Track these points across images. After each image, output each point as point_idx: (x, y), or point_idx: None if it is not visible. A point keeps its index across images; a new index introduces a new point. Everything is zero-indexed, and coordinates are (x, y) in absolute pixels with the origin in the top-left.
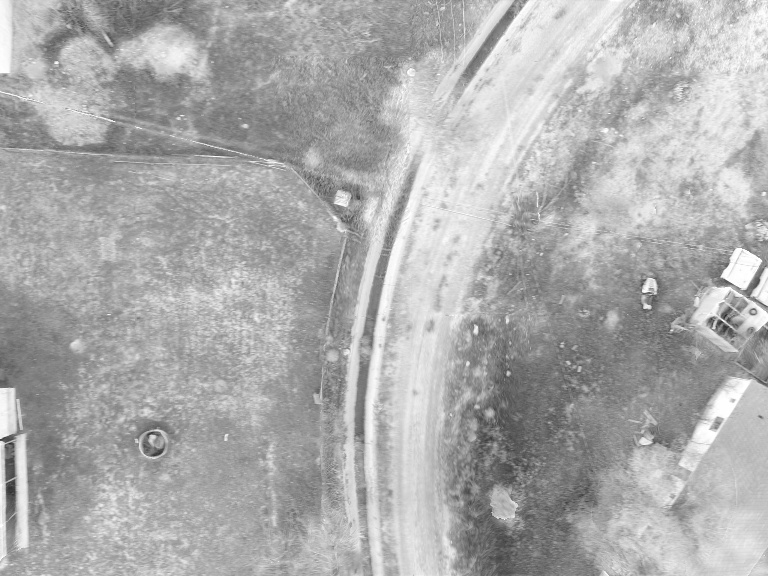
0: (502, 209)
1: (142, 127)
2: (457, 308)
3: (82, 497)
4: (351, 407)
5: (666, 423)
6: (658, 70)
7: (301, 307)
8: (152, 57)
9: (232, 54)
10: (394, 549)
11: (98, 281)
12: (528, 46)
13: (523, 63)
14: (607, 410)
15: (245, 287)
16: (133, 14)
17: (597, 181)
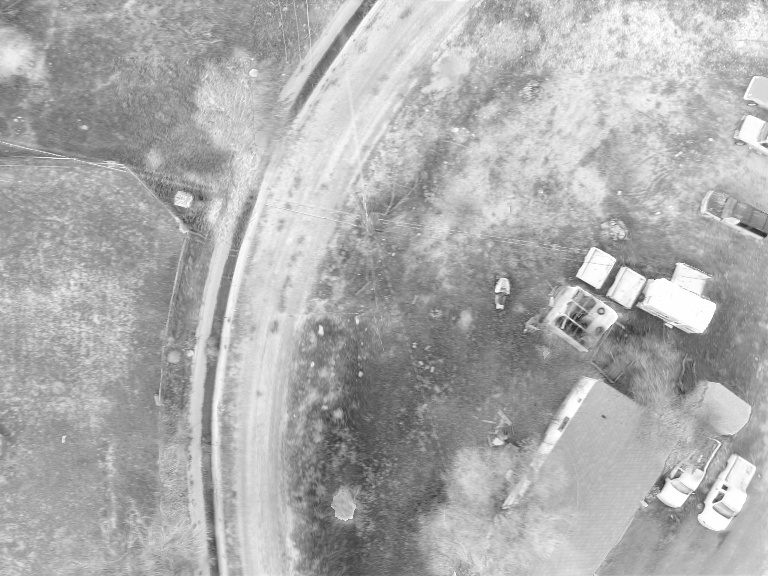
0: (346, 209)
1: None
2: (301, 309)
3: None
4: (197, 408)
5: (520, 423)
6: (509, 69)
7: (143, 308)
8: None
9: (70, 56)
10: (238, 551)
11: None
12: (374, 46)
13: (368, 63)
14: (460, 410)
15: (84, 288)
16: None
17: (450, 181)
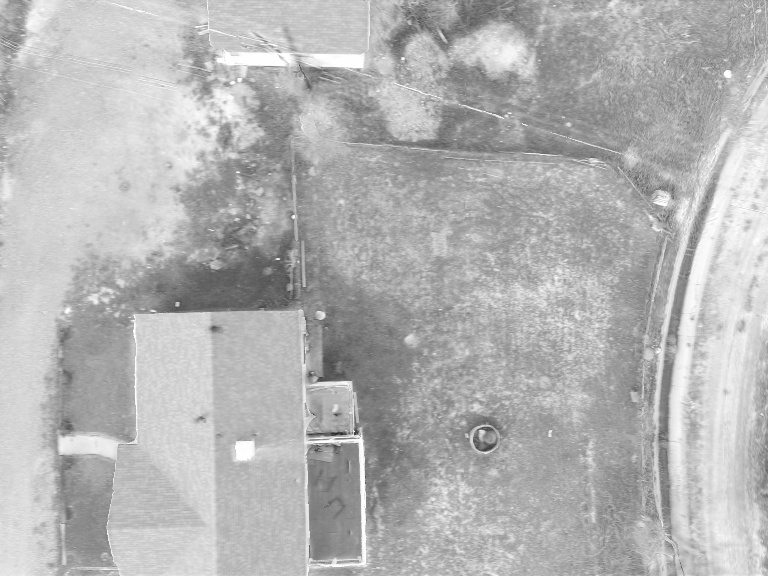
0: None
1: (472, 124)
2: (767, 308)
3: (415, 491)
4: (657, 405)
5: None
6: None
7: (618, 305)
8: (484, 54)
9: (558, 53)
10: (704, 547)
11: (430, 276)
12: None
13: None
14: None
15: (567, 284)
16: (468, 11)
17: None
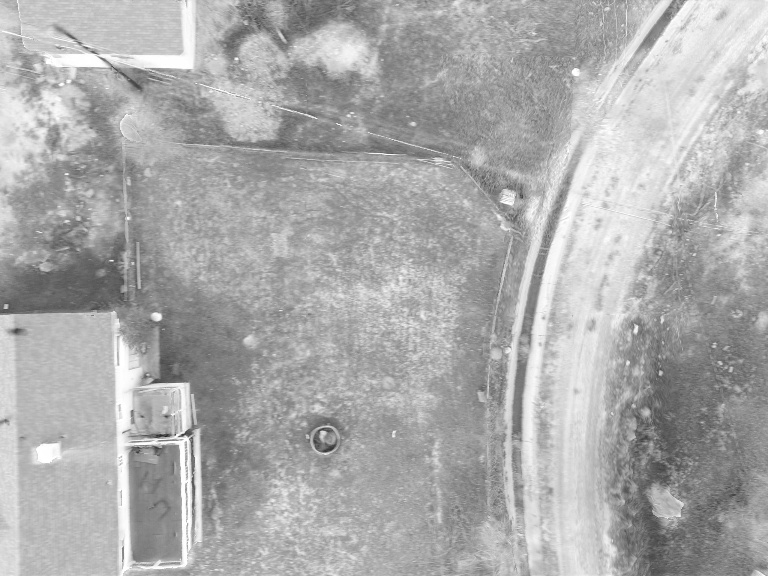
0: (663, 209)
1: (313, 124)
2: (618, 307)
3: (254, 492)
4: (509, 405)
5: None
6: None
7: (465, 305)
8: (325, 54)
9: (401, 52)
10: (554, 547)
11: (270, 277)
12: (689, 47)
13: (684, 64)
14: (758, 410)
15: (412, 284)
16: (307, 11)
17: (749, 182)
